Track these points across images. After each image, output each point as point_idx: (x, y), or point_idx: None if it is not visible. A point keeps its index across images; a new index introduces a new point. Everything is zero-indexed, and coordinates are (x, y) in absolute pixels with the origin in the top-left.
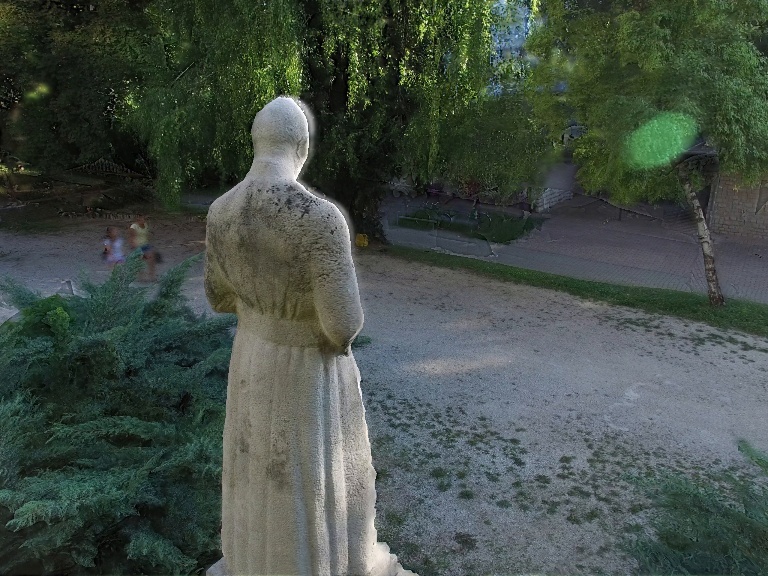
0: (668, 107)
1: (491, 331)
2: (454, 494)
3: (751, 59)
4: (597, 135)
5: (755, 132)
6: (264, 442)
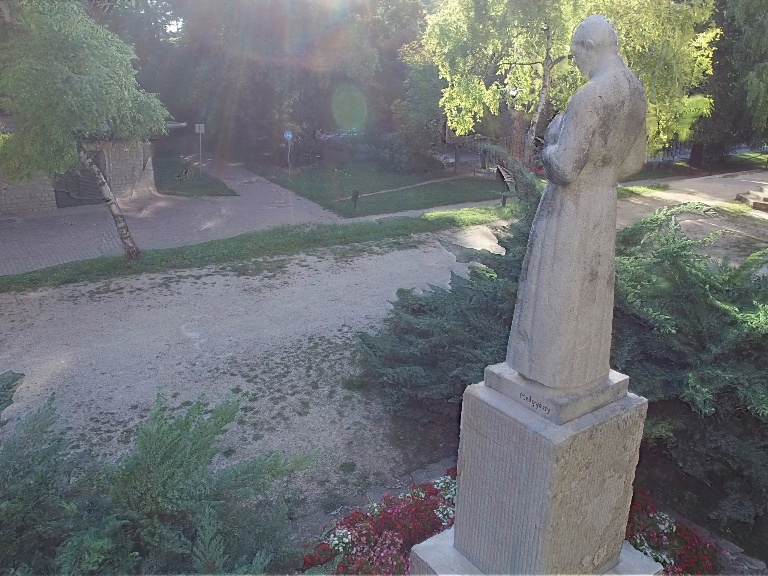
0: (82, 72)
1: None
2: (220, 458)
3: (98, 31)
4: None
5: None
6: None
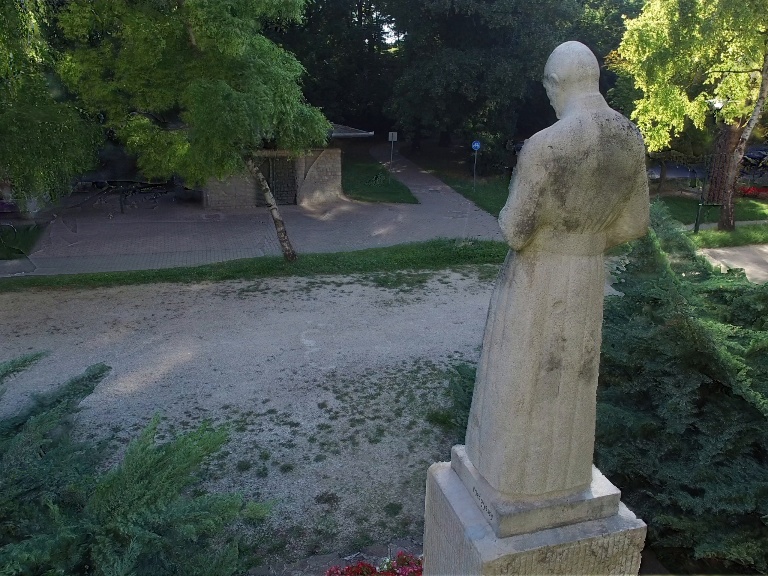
0: (245, 90)
1: (139, 335)
2: (276, 473)
3: (274, 50)
4: (142, 122)
5: (294, 111)
6: (579, 348)
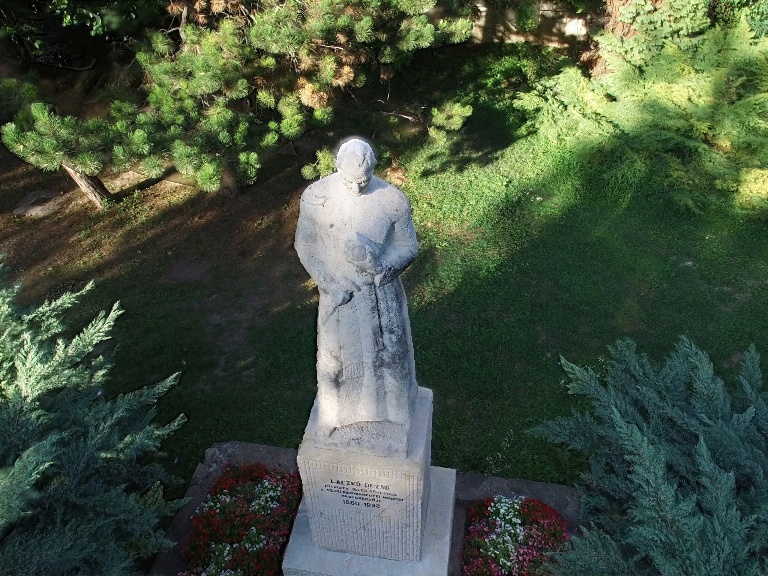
0: None
1: None
2: None
3: None
4: None
5: None
6: None
